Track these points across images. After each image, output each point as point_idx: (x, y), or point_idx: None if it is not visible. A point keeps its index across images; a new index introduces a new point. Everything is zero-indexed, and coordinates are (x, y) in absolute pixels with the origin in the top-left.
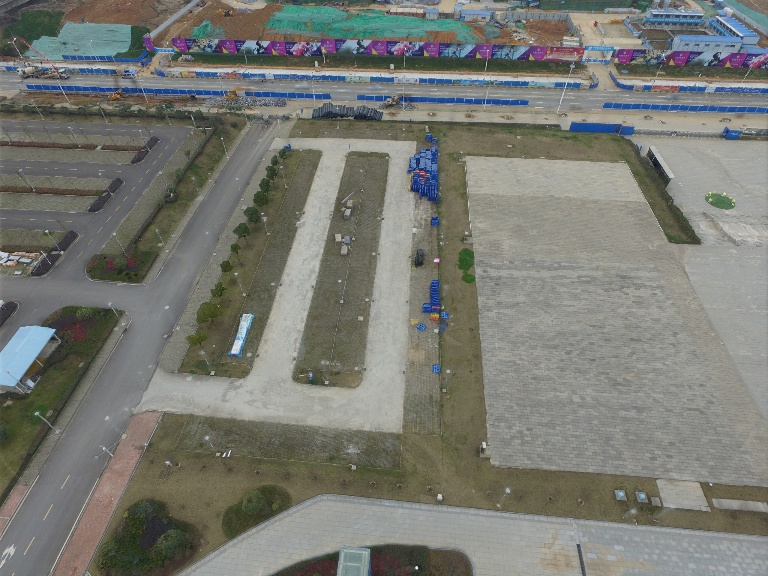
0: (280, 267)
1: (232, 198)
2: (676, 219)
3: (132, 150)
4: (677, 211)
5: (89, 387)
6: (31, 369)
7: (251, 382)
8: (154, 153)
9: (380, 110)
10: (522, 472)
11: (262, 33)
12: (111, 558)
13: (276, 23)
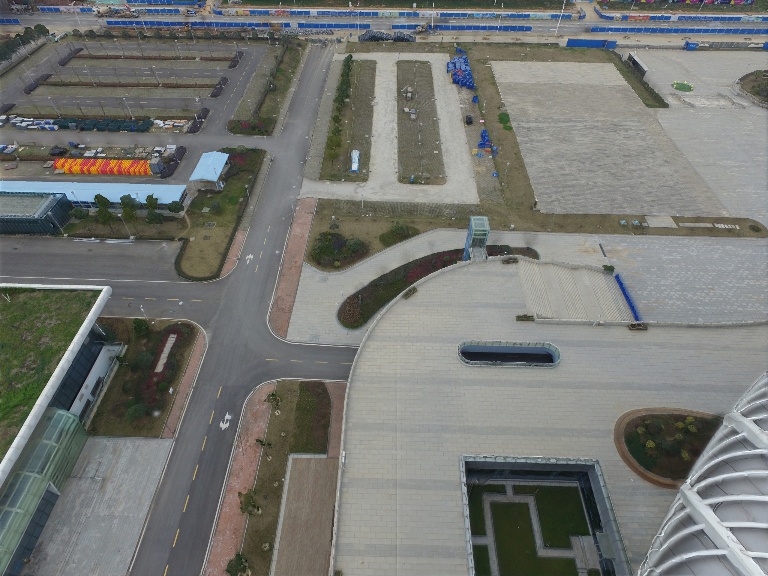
0: (369, 127)
1: (317, 89)
2: (651, 95)
3: (226, 60)
4: (652, 90)
5: (261, 187)
6: None
7: (371, 184)
8: (244, 62)
9: (413, 36)
10: (561, 215)
11: None
12: (318, 254)
13: None
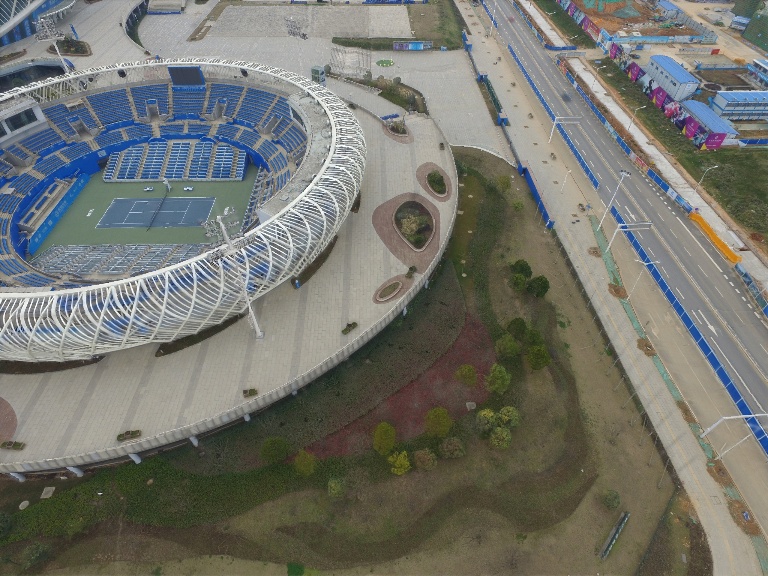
0: None
1: None
2: None
3: None
4: (362, 42)
5: None
6: None
7: None
8: None
9: None
10: None
11: None
12: None
13: None
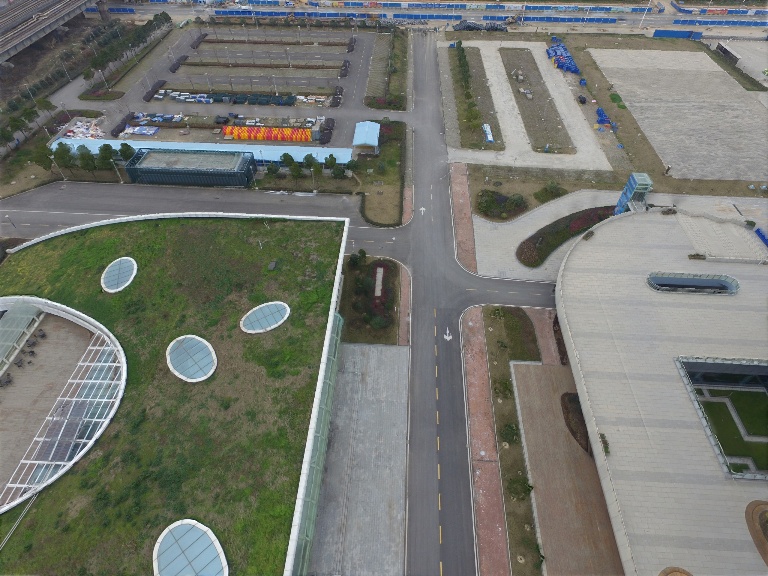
0: (491, 105)
1: (433, 71)
2: (748, 80)
3: (342, 45)
4: (748, 76)
5: (412, 153)
6: (370, 146)
7: (509, 152)
8: (358, 47)
9: (503, 26)
10: (692, 181)
11: None
12: (485, 207)
13: None
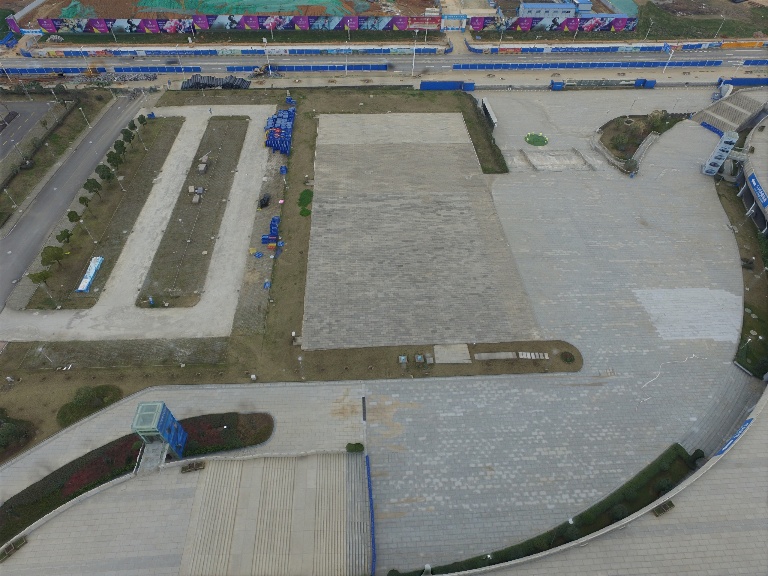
0: (133, 217)
1: (91, 162)
2: (494, 155)
3: None
4: (495, 149)
5: None
6: None
7: (96, 311)
8: (12, 126)
9: (248, 79)
10: (326, 352)
11: (134, 12)
12: None
13: (148, 2)
